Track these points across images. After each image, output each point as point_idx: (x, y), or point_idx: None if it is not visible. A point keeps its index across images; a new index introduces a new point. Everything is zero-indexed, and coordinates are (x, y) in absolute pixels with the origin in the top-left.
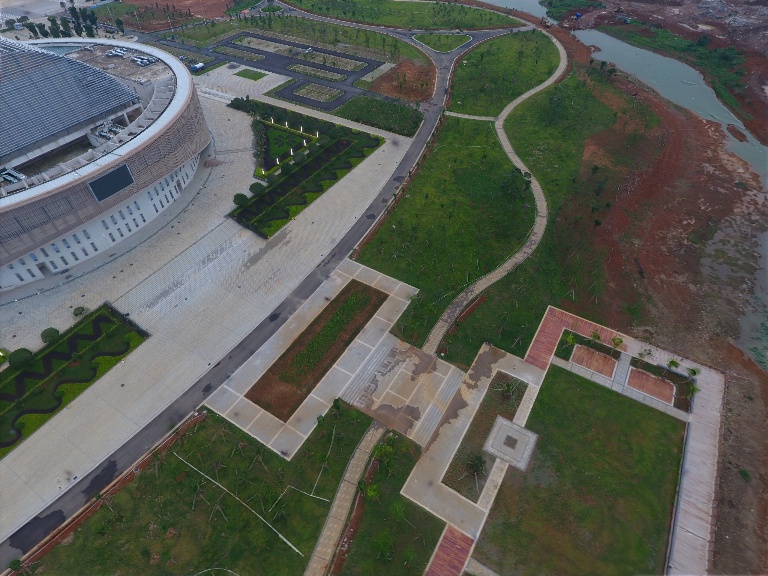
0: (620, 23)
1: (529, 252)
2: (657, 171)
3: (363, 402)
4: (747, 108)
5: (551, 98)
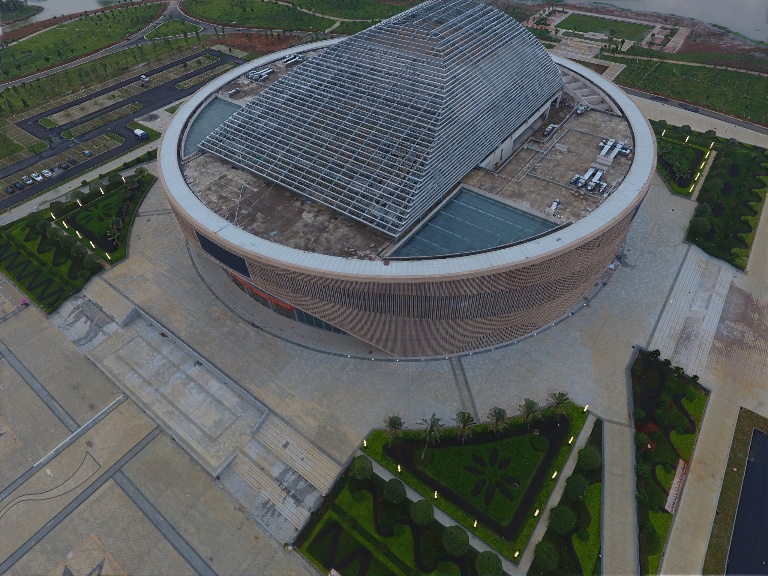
0: None
1: None
2: None
3: (590, 55)
4: None
5: None
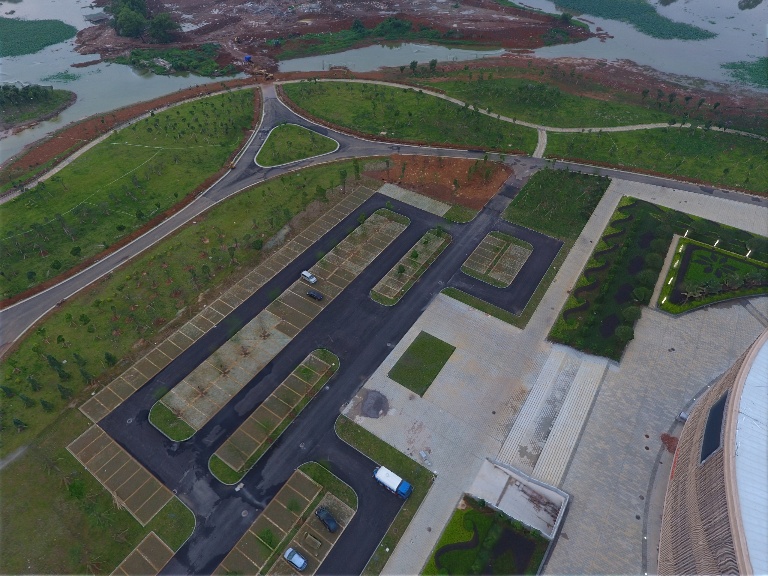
0: (275, 47)
1: (765, 138)
2: (605, 81)
3: None
4: (485, 40)
5: (531, 88)
